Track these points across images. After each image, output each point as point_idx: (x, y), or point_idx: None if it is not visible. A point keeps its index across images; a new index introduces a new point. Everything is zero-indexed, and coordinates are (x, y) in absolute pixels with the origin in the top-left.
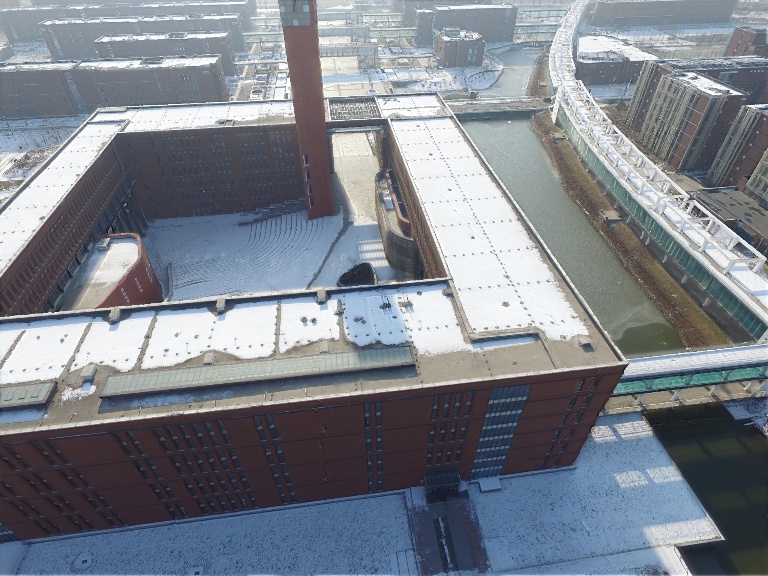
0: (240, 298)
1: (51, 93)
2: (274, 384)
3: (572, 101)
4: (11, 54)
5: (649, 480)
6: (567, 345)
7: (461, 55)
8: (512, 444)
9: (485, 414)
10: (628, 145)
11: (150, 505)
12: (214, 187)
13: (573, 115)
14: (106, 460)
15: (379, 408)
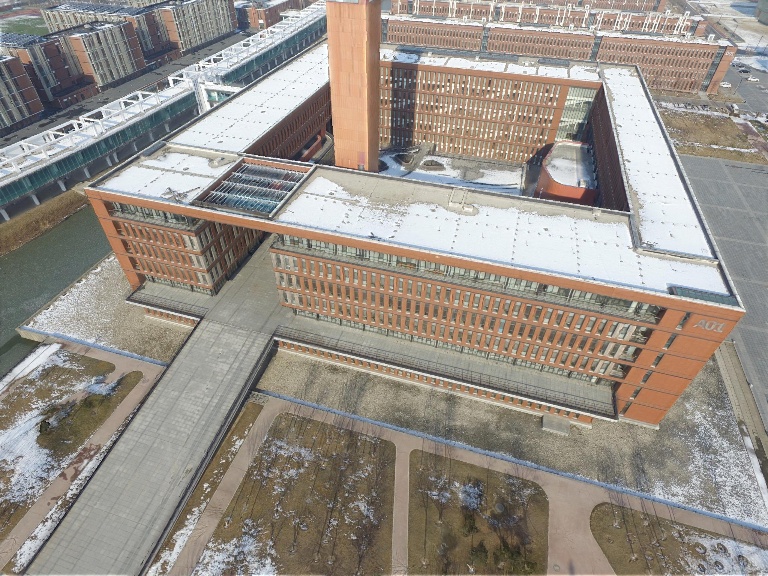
0: None
1: None
2: None
3: None
4: None
5: None
6: None
7: None
8: None
9: None
10: None
11: None
12: None
13: None
14: None
15: None
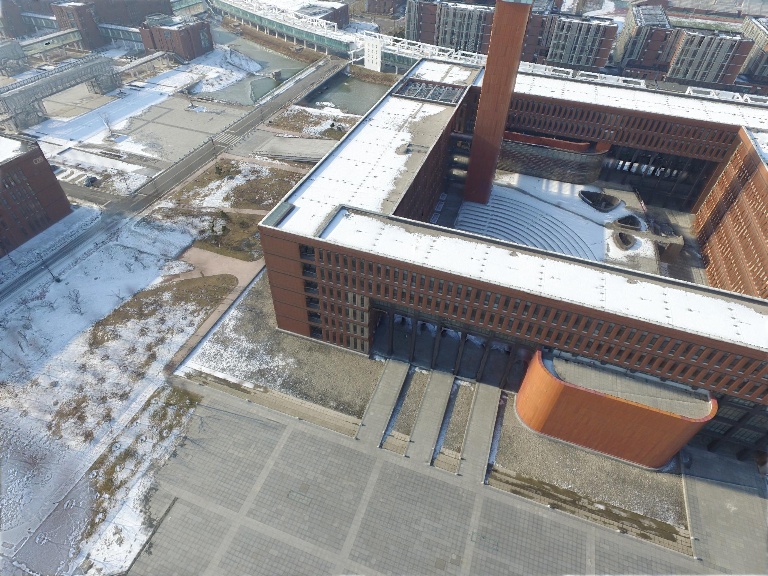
0: None
1: None
2: None
3: None
4: None
5: None
6: None
7: (196, 43)
8: None
9: None
10: None
11: None
12: None
13: (413, 56)
14: None
15: None
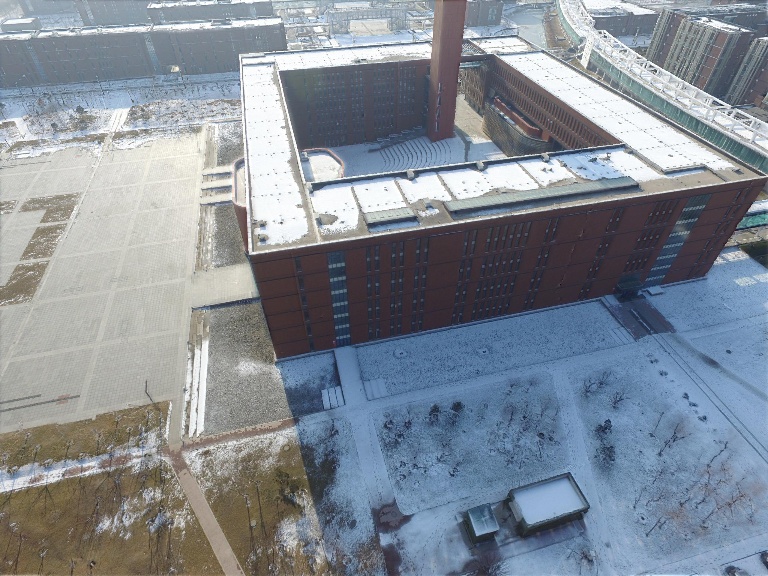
0: (490, 161)
1: (130, 55)
2: (556, 200)
3: (605, 46)
4: (40, 26)
5: (757, 281)
6: (725, 172)
7: (483, 15)
8: (679, 252)
9: (676, 221)
10: (668, 75)
11: (446, 308)
12: (346, 120)
13: (609, 57)
14: (448, 259)
15: (620, 214)
